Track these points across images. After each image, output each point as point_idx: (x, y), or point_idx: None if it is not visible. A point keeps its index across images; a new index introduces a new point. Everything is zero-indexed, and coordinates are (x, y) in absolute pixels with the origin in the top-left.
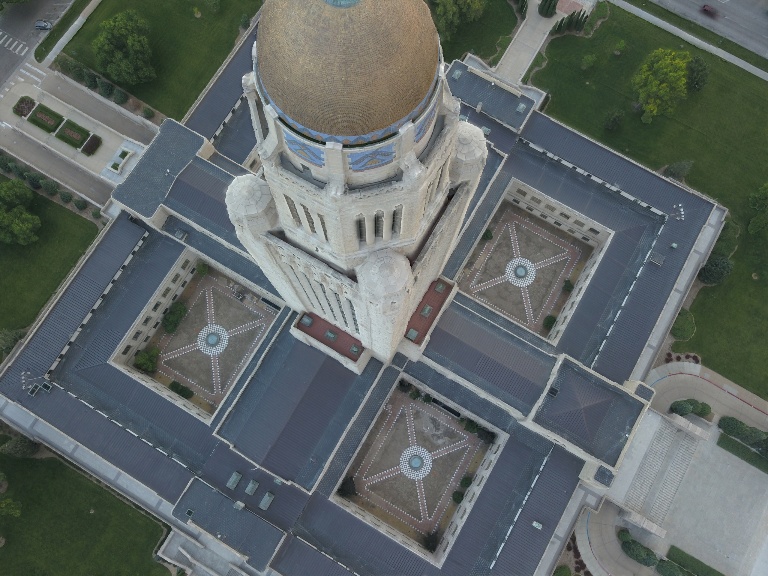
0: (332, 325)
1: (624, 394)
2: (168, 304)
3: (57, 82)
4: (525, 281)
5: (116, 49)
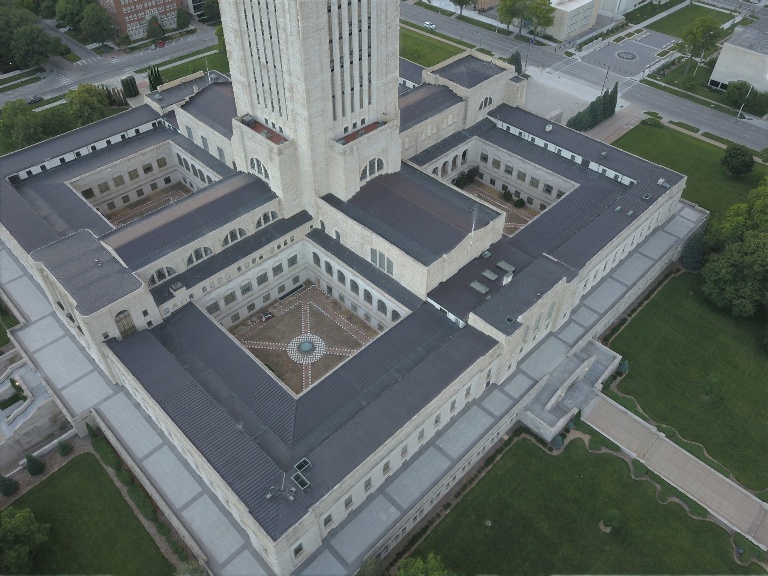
0: (352, 133)
1: (460, 61)
2: None
3: None
4: None
5: None
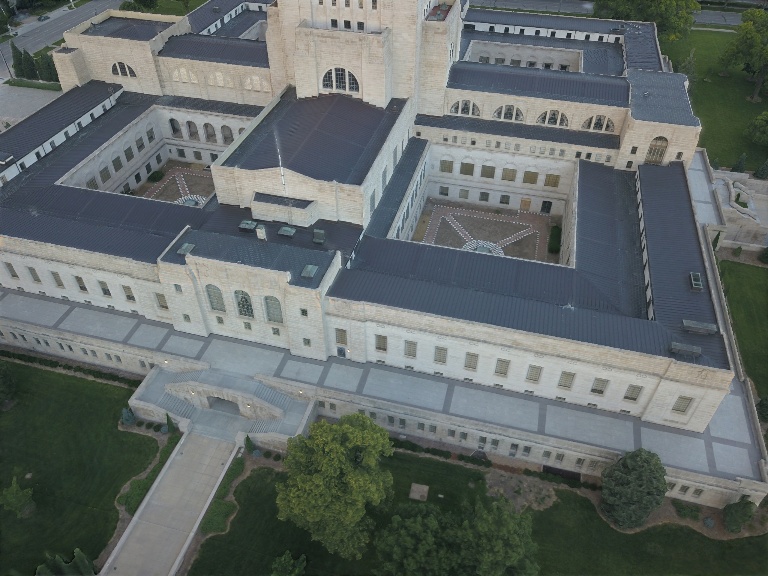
0: None
1: None
2: None
3: None
4: (185, 200)
5: None
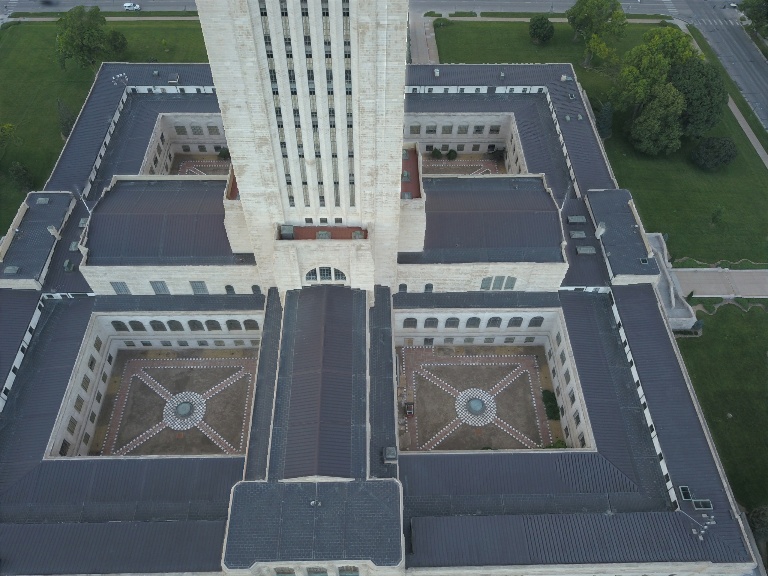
0: None
1: None
2: None
3: None
4: None
5: None
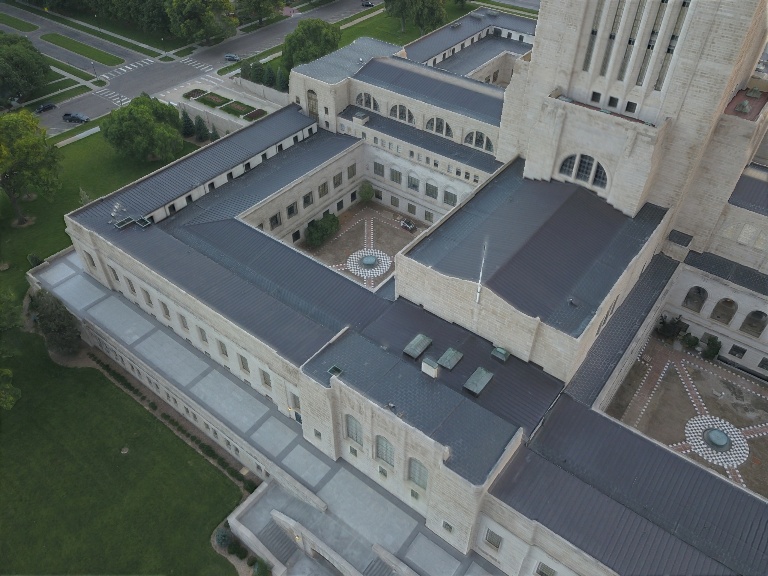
0: None
1: None
2: (318, 215)
3: (233, 86)
4: None
5: (308, 40)
